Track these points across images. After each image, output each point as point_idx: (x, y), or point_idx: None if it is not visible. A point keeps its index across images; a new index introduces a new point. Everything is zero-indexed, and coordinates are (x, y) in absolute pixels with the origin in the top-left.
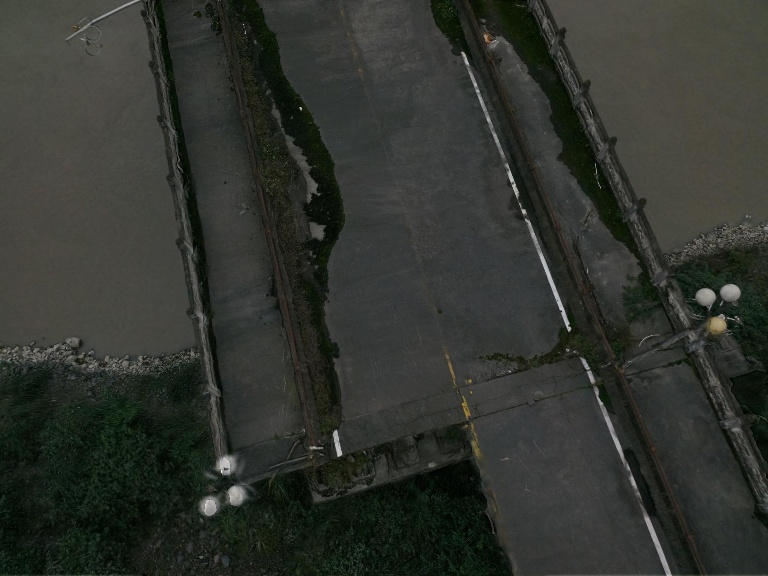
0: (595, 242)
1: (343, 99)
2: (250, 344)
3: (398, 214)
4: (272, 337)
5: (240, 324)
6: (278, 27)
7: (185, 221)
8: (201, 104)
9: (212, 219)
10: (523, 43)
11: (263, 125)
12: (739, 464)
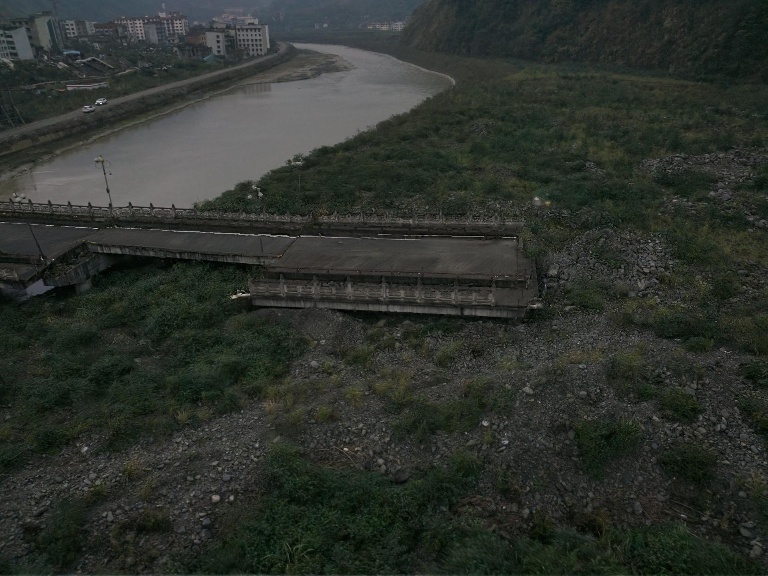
0: None
1: None
2: None
3: None
4: (1, 265)
5: None
6: None
7: None
8: None
9: None
10: None
11: None
12: (163, 218)
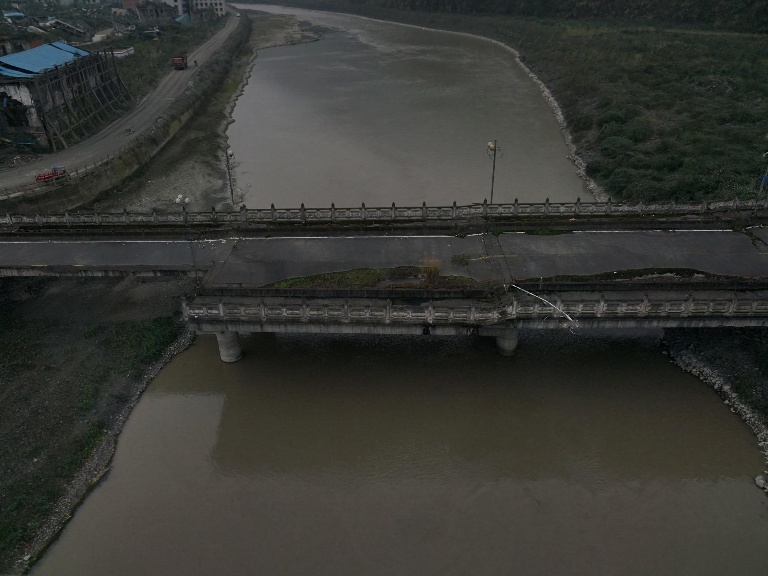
0: None
1: (607, 261)
2: None
3: (682, 255)
4: None
5: None
6: (552, 274)
7: None
8: None
9: None
10: None
11: None
12: None
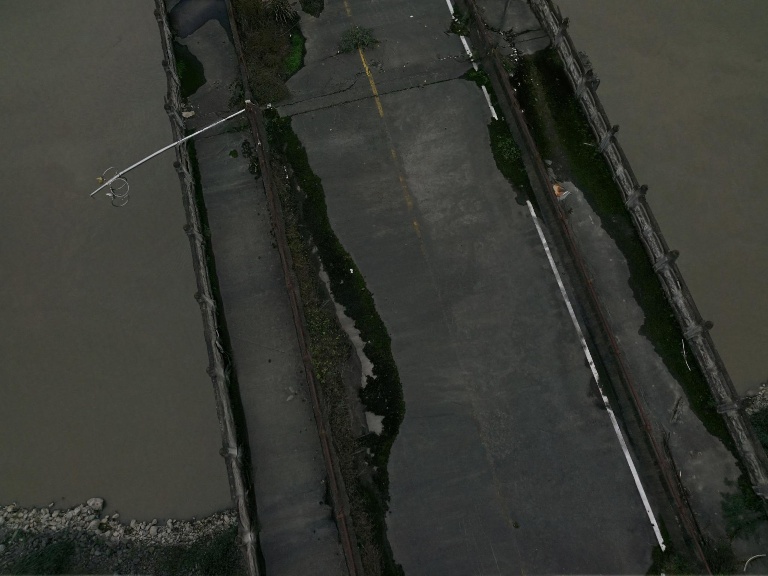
0: (687, 437)
1: (398, 259)
2: (303, 565)
3: (465, 402)
4: (328, 556)
5: (291, 539)
6: (323, 170)
7: (227, 416)
8: (240, 263)
9: (256, 408)
10: (594, 190)
11: (310, 292)
12: None
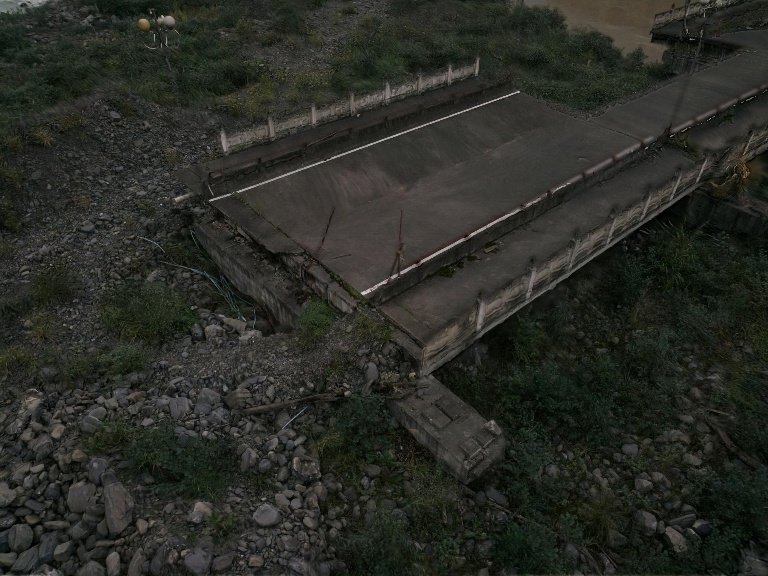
0: None
1: None
2: None
3: None
4: None
5: None
6: None
7: None
8: None
9: None
10: None
11: (763, 14)
12: None
